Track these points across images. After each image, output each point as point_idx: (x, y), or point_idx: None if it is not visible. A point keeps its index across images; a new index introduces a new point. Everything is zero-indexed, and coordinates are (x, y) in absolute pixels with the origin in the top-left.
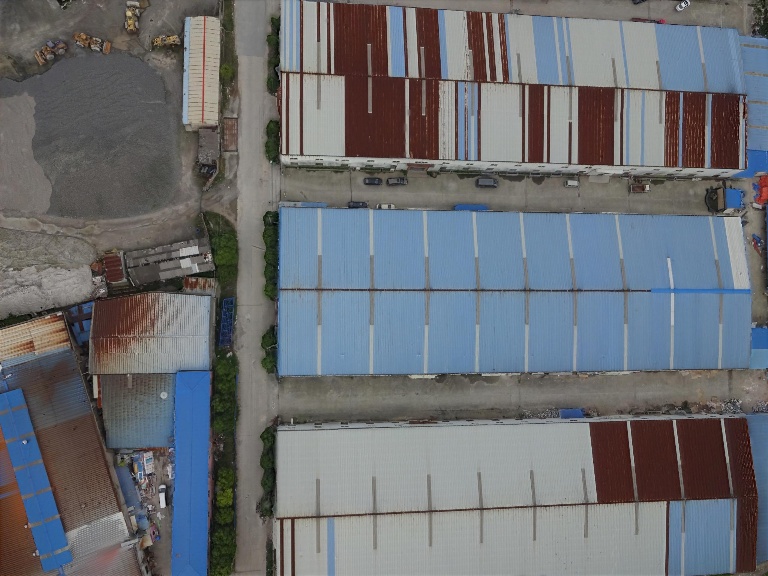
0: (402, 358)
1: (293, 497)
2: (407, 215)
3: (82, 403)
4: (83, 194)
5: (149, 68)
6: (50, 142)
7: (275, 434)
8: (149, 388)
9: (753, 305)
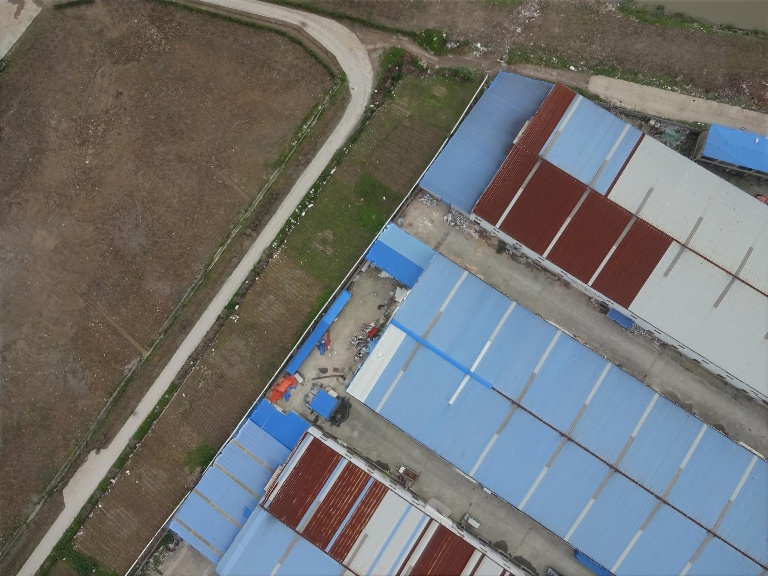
0: None
1: None
2: None
3: None
4: None
5: None
6: None
7: None
8: None
9: (369, 292)
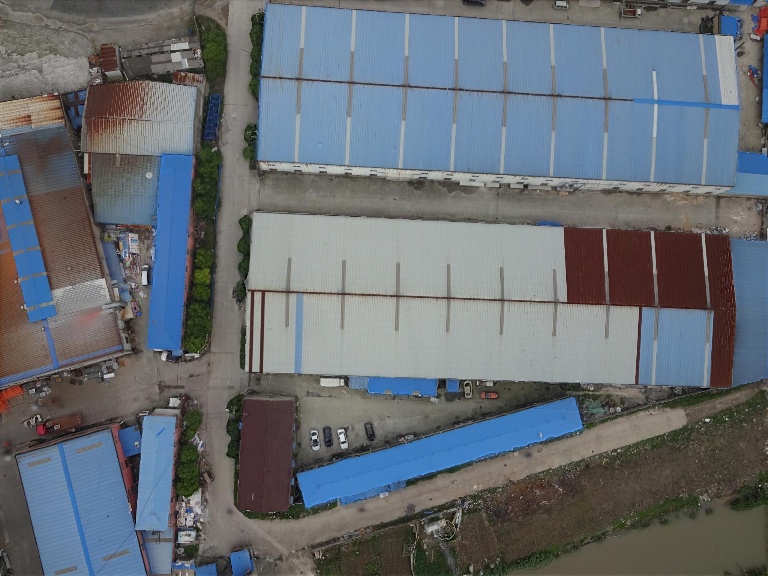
0: (378, 151)
1: (265, 272)
2: (390, 17)
3: (73, 176)
4: None
5: None
6: None
7: (252, 217)
8: (136, 168)
9: (746, 135)
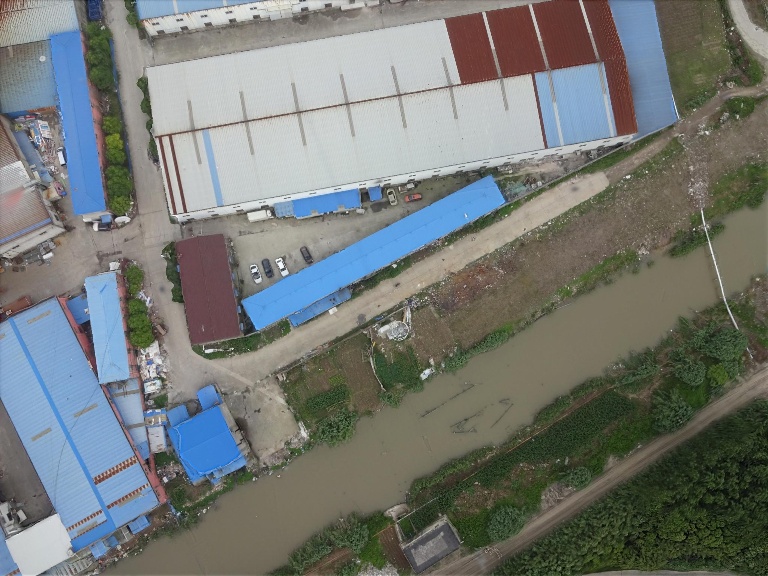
0: None
1: (168, 118)
2: None
3: None
4: None
5: None
6: None
7: None
8: (28, 55)
9: None
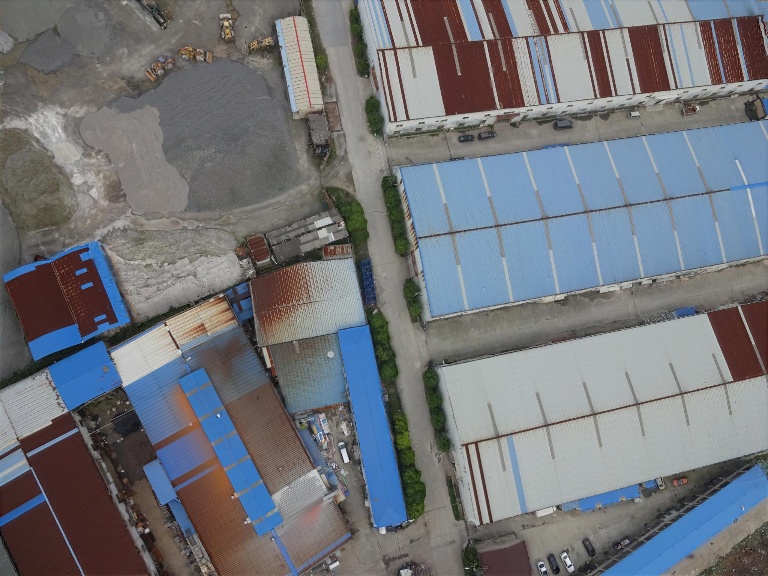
0: (535, 283)
1: (471, 423)
2: (510, 158)
3: (259, 374)
4: (218, 186)
5: (250, 69)
6: (179, 145)
7: (439, 371)
8: (316, 350)
9: None
